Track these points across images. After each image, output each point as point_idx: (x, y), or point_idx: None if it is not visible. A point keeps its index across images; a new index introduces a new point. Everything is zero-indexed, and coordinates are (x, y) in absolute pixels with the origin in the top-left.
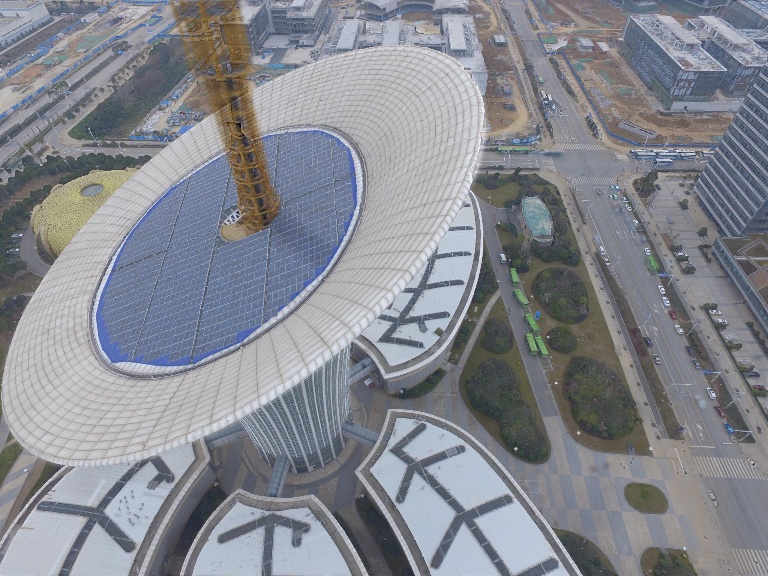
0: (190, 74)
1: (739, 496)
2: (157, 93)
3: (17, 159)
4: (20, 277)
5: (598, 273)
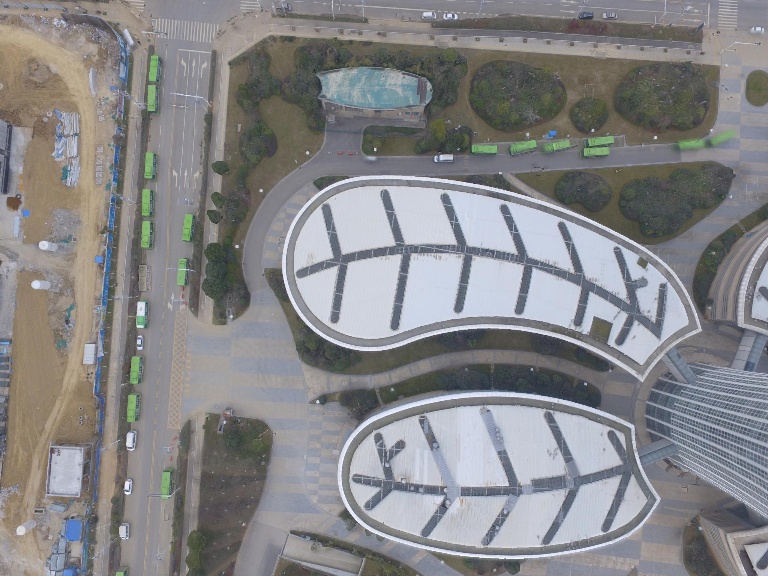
0: None
1: (754, 5)
2: None
3: None
4: None
5: (473, 36)
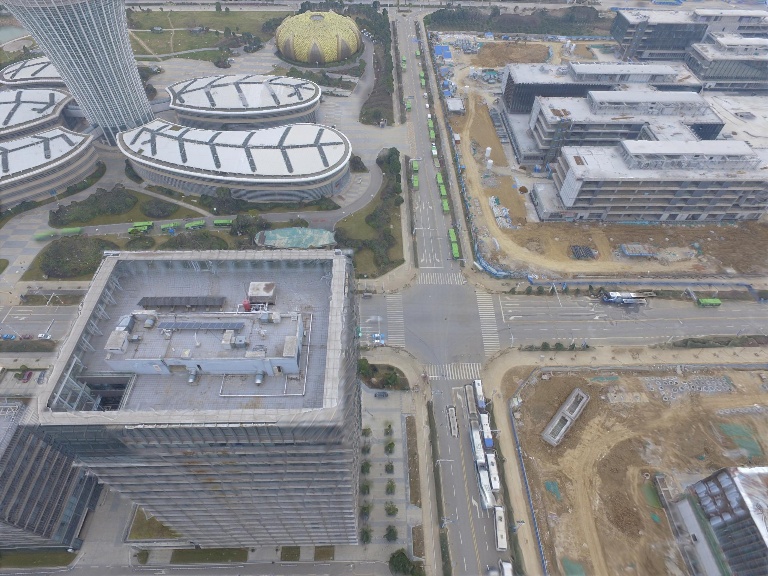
0: (556, 37)
1: None
2: (501, 27)
3: (393, 7)
4: (271, 34)
5: None
